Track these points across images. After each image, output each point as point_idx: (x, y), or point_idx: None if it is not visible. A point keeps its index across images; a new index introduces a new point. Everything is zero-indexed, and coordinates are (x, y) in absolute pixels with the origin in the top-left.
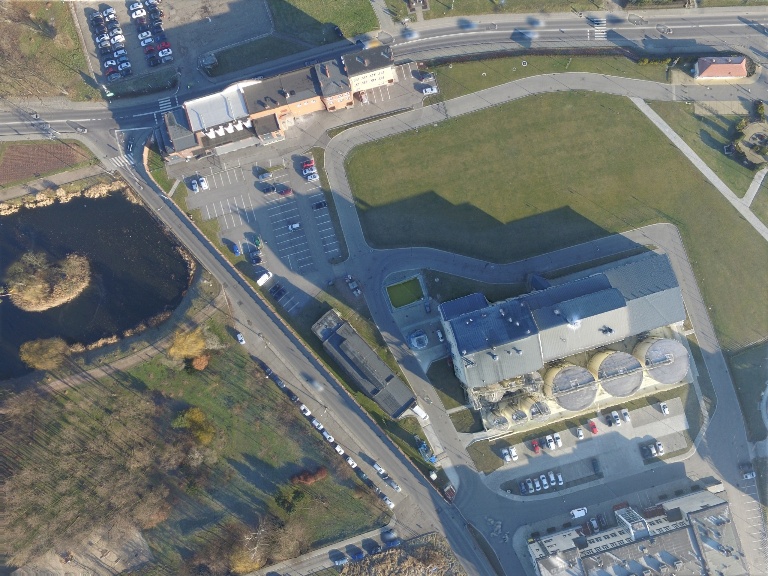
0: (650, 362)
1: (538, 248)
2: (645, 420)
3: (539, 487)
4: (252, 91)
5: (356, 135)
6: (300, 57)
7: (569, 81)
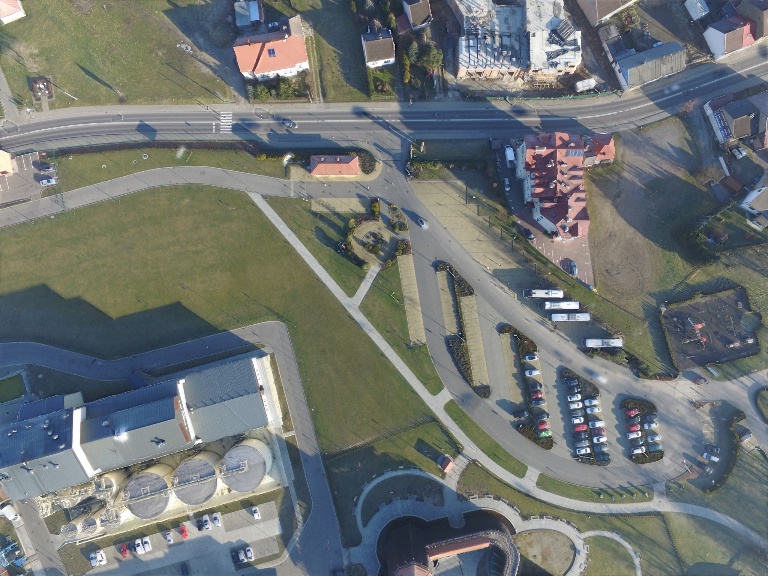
0: (222, 470)
1: (147, 344)
2: (238, 524)
3: None
4: None
5: None
6: None
7: (189, 175)
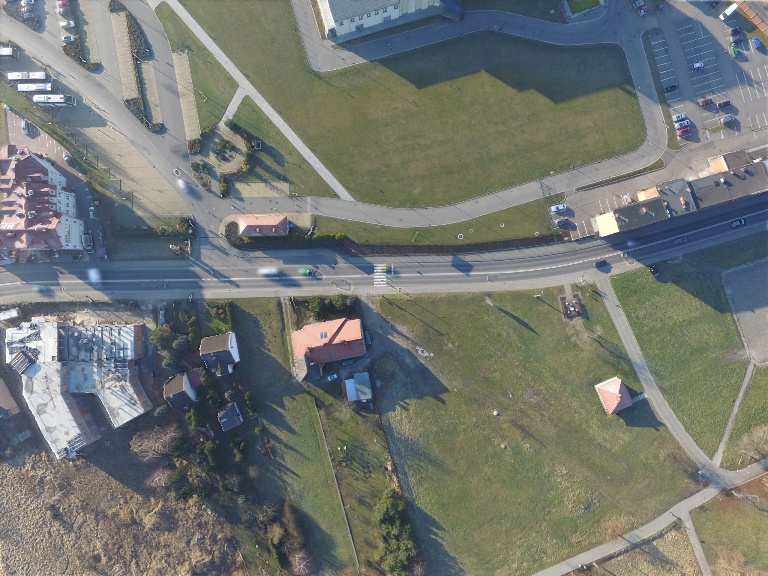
0: None
1: (449, 46)
2: None
3: None
4: (760, 186)
5: (635, 162)
6: (693, 247)
7: (415, 218)
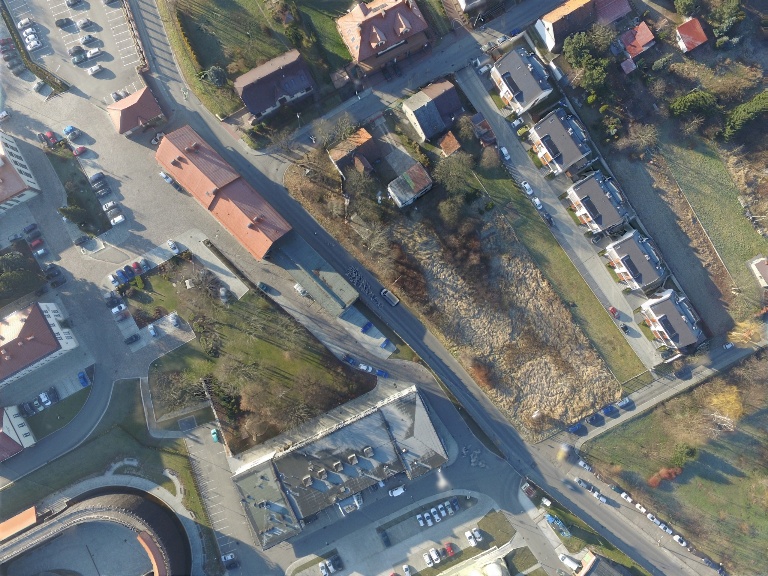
0: None
1: None
2: None
3: (441, 510)
4: None
5: None
6: None
7: None
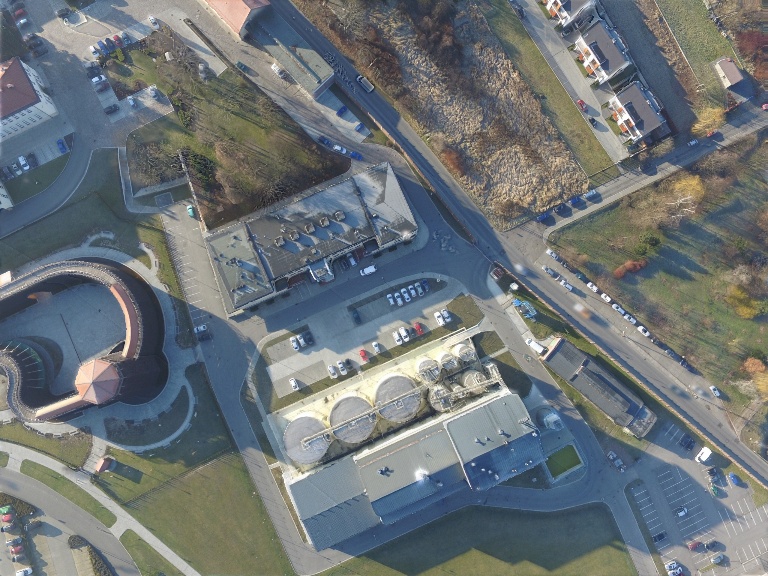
0: (326, 438)
1: (436, 528)
2: (312, 370)
3: (411, 290)
4: None
5: None
6: None
7: None
